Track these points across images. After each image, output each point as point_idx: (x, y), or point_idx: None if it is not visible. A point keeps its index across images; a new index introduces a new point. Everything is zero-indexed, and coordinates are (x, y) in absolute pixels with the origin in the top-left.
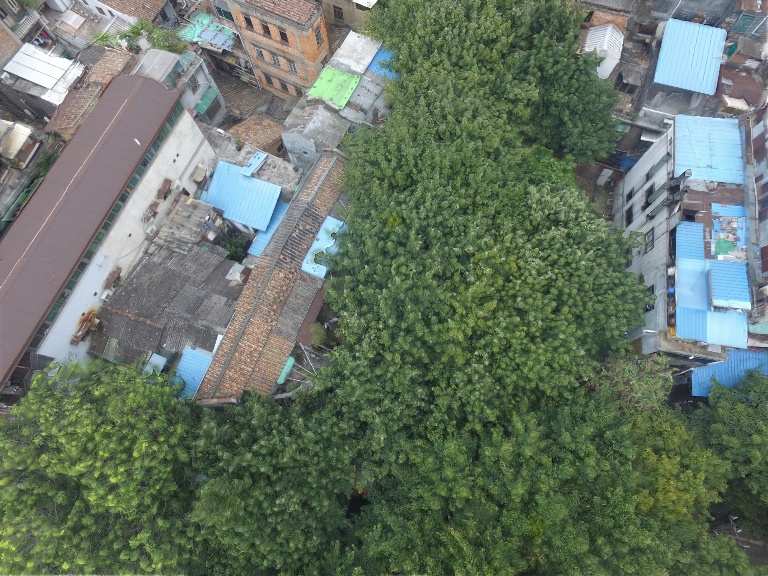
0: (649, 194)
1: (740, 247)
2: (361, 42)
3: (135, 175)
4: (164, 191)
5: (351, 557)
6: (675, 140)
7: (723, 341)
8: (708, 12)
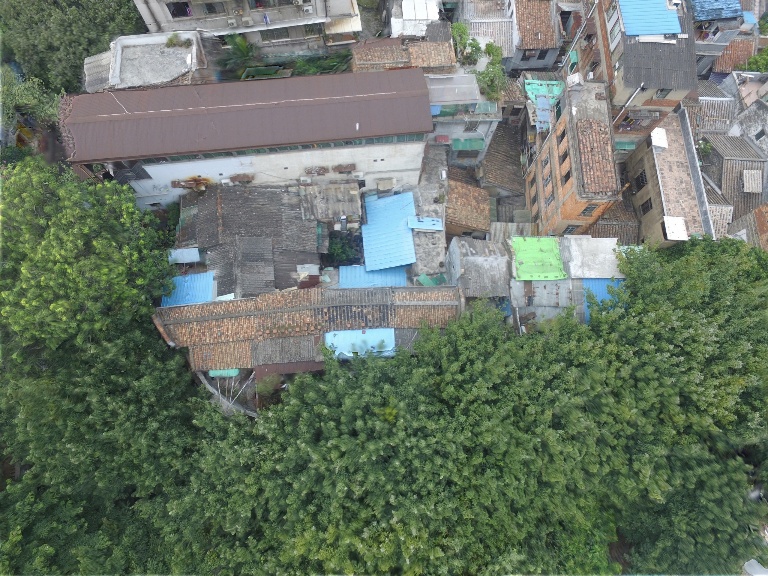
0: None
1: None
2: (609, 256)
3: (331, 142)
4: (342, 169)
5: (72, 530)
6: None
7: None
8: None
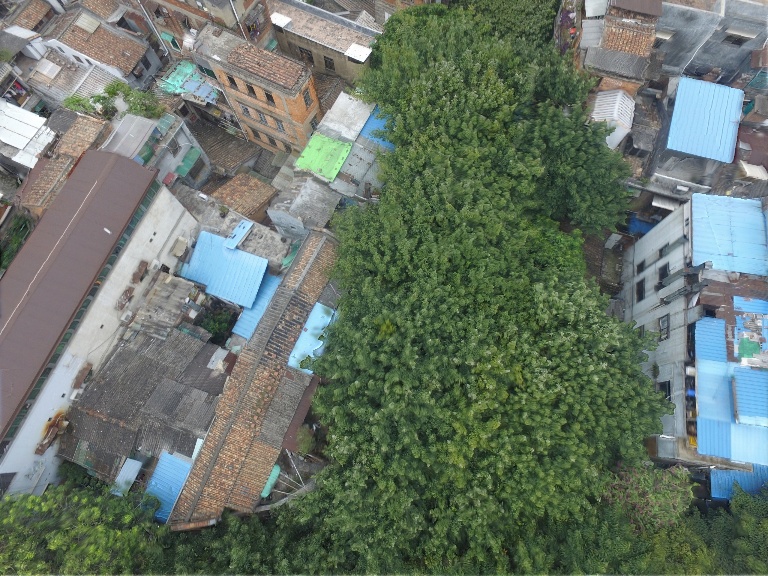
0: (663, 274)
1: (766, 350)
2: (353, 105)
3: (106, 266)
4: (140, 275)
5: None
6: (693, 223)
7: (749, 457)
8: (722, 64)
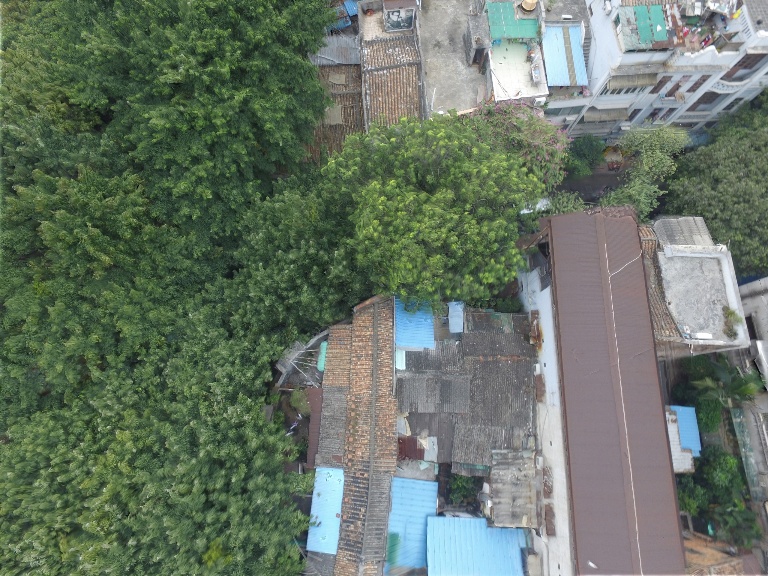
0: None
1: None
2: None
3: None
4: (548, 517)
5: (213, 228)
6: None
7: None
8: None
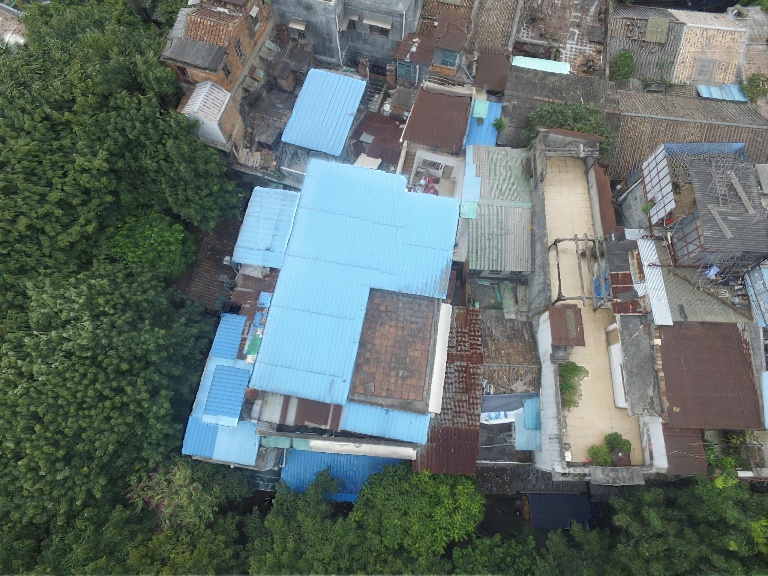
0: None
1: None
2: None
3: None
4: None
5: None
6: None
7: (230, 457)
8: (386, 56)
